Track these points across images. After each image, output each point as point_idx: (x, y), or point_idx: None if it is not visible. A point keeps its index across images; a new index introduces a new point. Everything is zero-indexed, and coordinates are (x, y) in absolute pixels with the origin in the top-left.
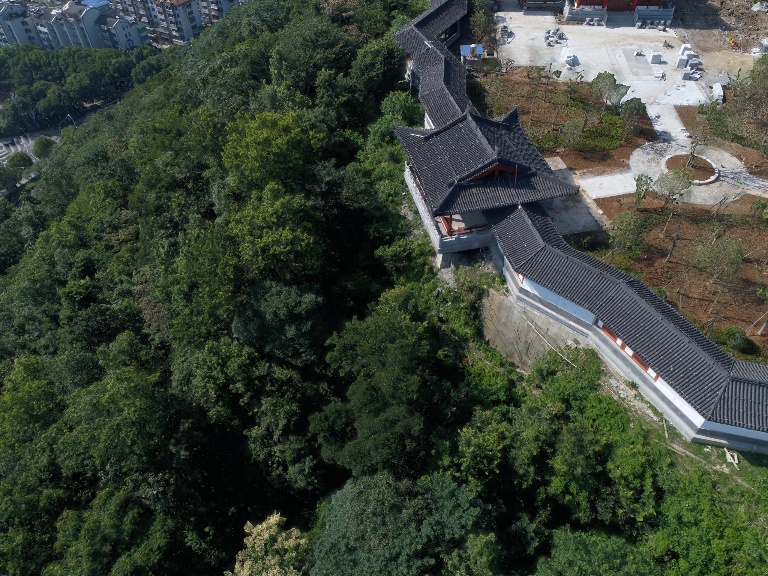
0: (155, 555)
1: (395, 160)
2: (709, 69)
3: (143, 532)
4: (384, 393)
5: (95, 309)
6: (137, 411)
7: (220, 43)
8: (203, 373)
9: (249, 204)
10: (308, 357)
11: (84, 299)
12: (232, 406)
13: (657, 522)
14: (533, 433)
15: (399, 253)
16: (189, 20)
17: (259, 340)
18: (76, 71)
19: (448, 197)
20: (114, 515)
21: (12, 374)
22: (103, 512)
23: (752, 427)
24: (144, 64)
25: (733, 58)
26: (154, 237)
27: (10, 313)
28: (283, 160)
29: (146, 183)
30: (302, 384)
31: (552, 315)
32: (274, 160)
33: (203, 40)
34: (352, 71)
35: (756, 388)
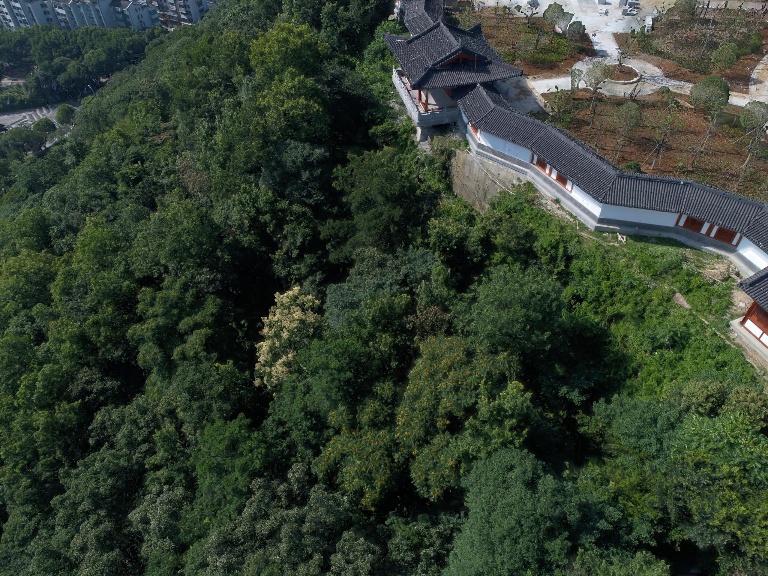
0: (209, 317)
1: (385, 70)
2: (645, 8)
3: (199, 305)
4: (375, 201)
5: (149, 180)
6: (194, 221)
7: (234, 4)
8: (239, 207)
9: (273, 84)
10: (318, 197)
11: (136, 180)
12: (260, 236)
13: (567, 280)
14: (482, 225)
15: (388, 130)
16: (197, 4)
17: (281, 187)
18: (93, 48)
19: (424, 77)
20: (179, 291)
21: (83, 231)
22: (171, 290)
23: (630, 205)
24: (157, 41)
25: (666, 0)
26: (195, 124)
27: (74, 196)
28: (298, 56)
29: (187, 84)
30: (313, 220)
31: (501, 161)
32: (291, 55)
33: (218, 3)
34: (351, 6)
35: (634, 181)
